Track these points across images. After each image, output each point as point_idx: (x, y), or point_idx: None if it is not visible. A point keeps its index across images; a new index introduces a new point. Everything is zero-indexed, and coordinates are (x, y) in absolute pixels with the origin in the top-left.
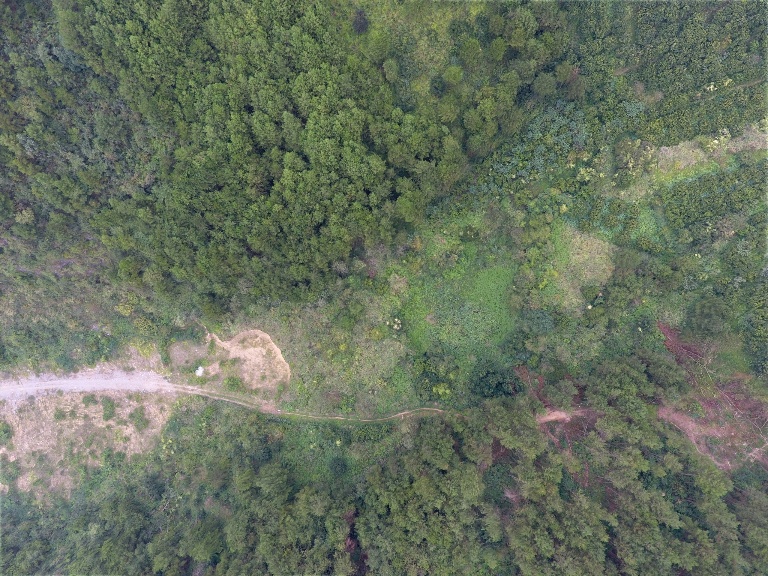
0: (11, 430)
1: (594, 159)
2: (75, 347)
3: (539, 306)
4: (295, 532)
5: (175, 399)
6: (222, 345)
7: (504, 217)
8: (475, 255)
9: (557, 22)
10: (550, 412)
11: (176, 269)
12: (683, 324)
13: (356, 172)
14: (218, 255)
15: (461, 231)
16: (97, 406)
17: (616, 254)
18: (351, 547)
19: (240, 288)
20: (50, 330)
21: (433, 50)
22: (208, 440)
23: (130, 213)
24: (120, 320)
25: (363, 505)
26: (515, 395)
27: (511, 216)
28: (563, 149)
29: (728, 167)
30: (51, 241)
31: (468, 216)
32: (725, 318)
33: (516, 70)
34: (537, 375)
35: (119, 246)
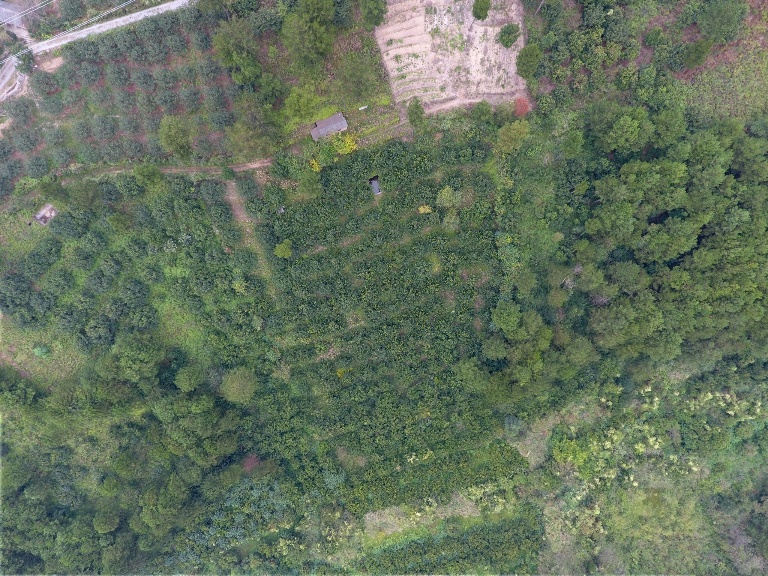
0: None
1: (295, 529)
2: None
3: None
4: None
5: None
6: None
7: None
8: None
9: (217, 432)
10: None
11: None
12: None
13: None
14: None
15: None
16: None
17: None
18: None
19: None
20: None
21: (95, 453)
22: None
23: None
24: None
25: None
26: None
27: None
28: None
29: (437, 533)
30: None
31: None
32: None
33: (179, 477)
34: None
35: None
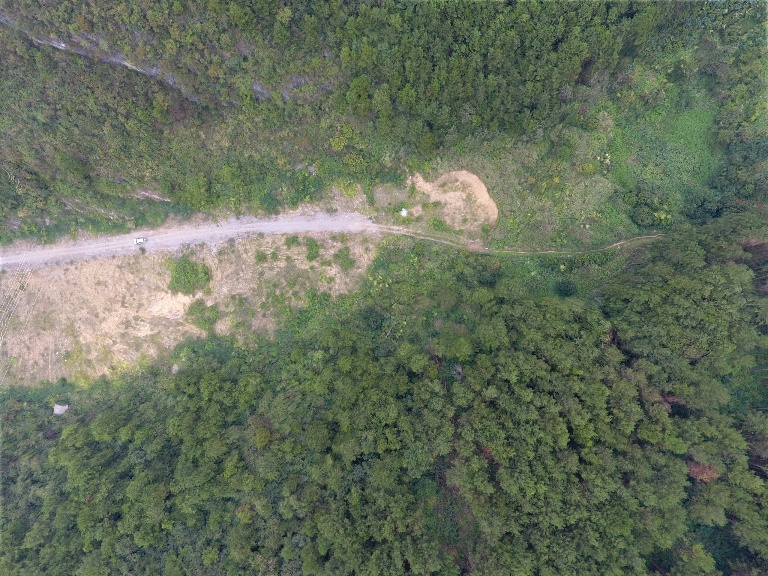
0: (210, 274)
1: None
2: (281, 185)
3: (752, 137)
4: (562, 324)
5: (380, 239)
6: (422, 189)
7: (714, 53)
8: (676, 97)
9: None
10: None
11: (408, 90)
12: None
13: None
14: (458, 69)
15: (670, 68)
16: (300, 247)
17: None
18: (614, 341)
19: (462, 116)
20: (260, 165)
21: None
22: (423, 273)
23: (382, 19)
24: (327, 158)
25: (613, 309)
26: (744, 212)
27: (722, 51)
28: None
29: None
30: (295, 51)
31: (679, 51)
32: None
33: None
34: (754, 202)
35: (355, 63)
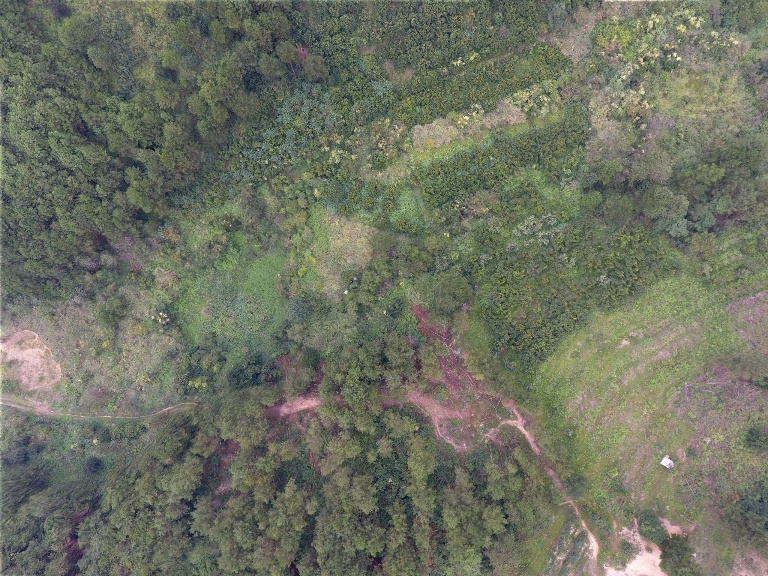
0: None
1: (346, 141)
2: None
3: (298, 293)
4: (9, 534)
5: None
6: None
7: (262, 204)
8: (246, 245)
9: (272, 1)
10: (303, 401)
11: None
12: (431, 305)
13: (72, 163)
14: None
15: None
16: None
17: (373, 237)
18: (70, 547)
19: None
20: None
21: (152, 35)
22: None
23: None
24: None
25: (94, 504)
26: (262, 385)
27: (267, 203)
28: (315, 132)
29: (485, 143)
30: None
31: (225, 205)
32: (457, 297)
33: (236, 52)
34: (296, 364)
35: None
